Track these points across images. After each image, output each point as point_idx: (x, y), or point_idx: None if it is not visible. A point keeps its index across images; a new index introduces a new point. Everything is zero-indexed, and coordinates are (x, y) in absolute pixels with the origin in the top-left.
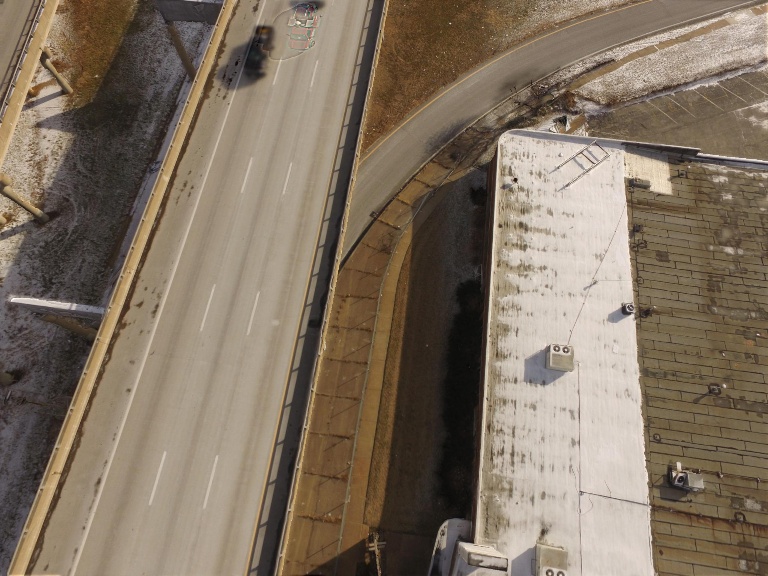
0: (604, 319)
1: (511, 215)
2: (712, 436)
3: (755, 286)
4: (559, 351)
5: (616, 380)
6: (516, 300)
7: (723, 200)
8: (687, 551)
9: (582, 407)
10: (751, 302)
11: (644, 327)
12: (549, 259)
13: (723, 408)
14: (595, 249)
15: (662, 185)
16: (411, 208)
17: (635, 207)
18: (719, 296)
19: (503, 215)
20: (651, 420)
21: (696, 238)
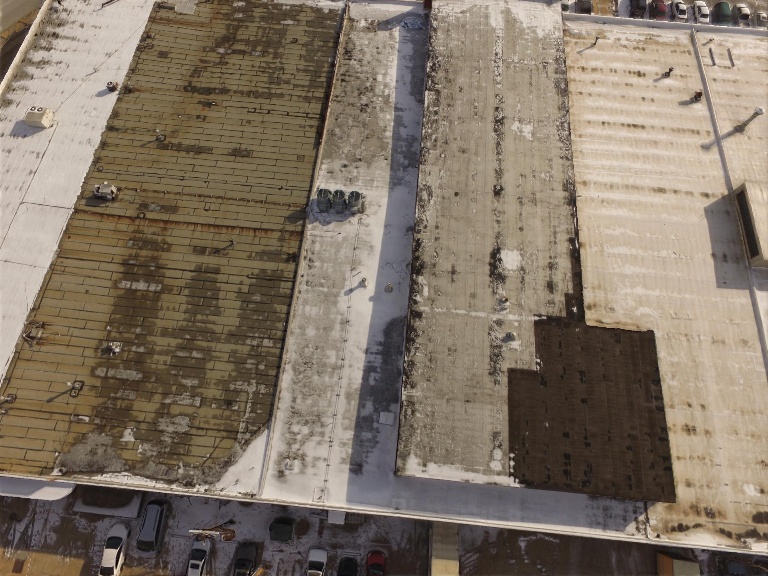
0: (93, 95)
1: (48, 27)
2: (144, 167)
3: (228, 73)
4: (34, 110)
5: (83, 133)
6: (26, 84)
7: (234, 18)
8: (90, 236)
9: (48, 150)
10: (219, 83)
11: (124, 100)
12: (66, 56)
13: (161, 149)
14: (107, 49)
15: (187, 8)
16: (5, 40)
17: (155, 22)
18: (196, 80)
19: (41, 28)
20: (101, 158)
21: (198, 43)
